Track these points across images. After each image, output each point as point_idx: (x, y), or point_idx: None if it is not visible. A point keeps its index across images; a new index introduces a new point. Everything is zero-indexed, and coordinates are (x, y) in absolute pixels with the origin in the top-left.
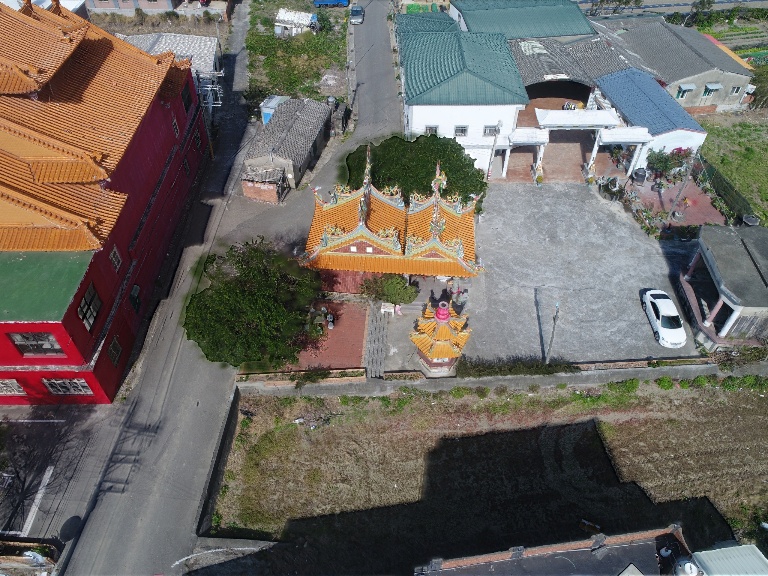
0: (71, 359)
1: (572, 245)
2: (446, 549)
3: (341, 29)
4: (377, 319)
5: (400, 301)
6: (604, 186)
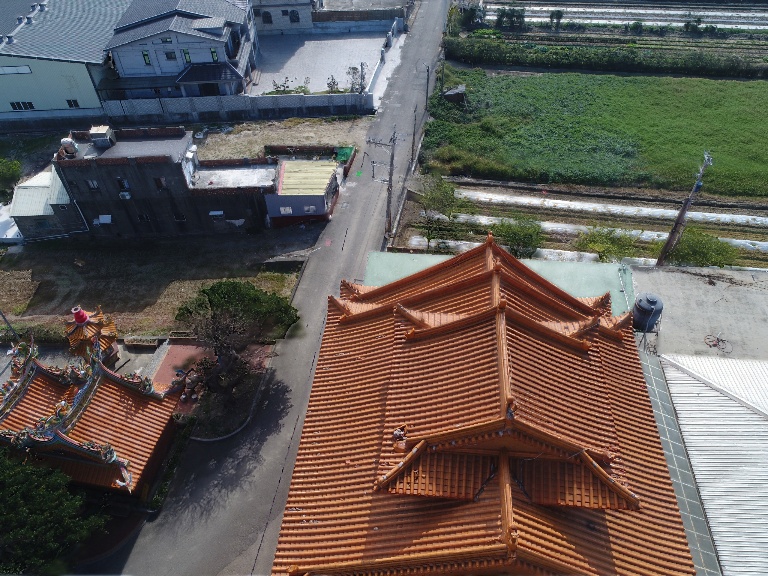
0: None
1: None
2: (168, 260)
3: None
4: None
5: None
6: None
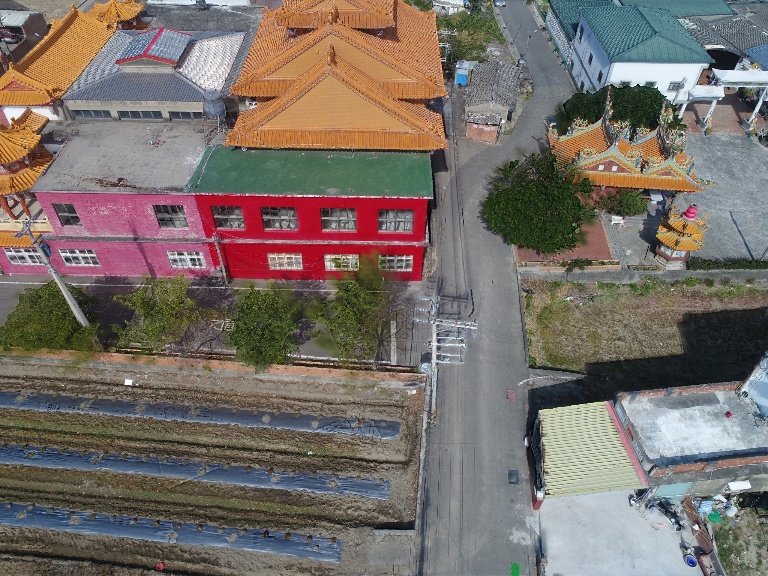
0: (414, 236)
1: (750, 181)
2: None
3: (488, 11)
4: (610, 228)
5: (635, 212)
6: (765, 137)
